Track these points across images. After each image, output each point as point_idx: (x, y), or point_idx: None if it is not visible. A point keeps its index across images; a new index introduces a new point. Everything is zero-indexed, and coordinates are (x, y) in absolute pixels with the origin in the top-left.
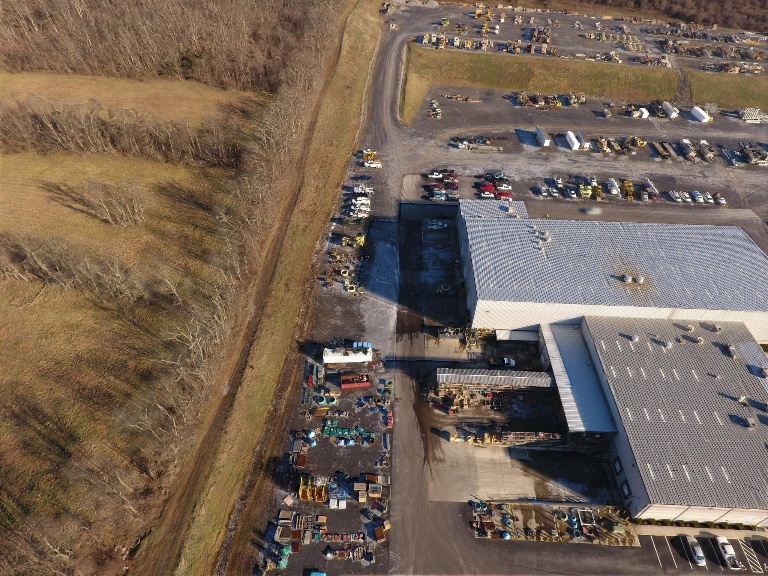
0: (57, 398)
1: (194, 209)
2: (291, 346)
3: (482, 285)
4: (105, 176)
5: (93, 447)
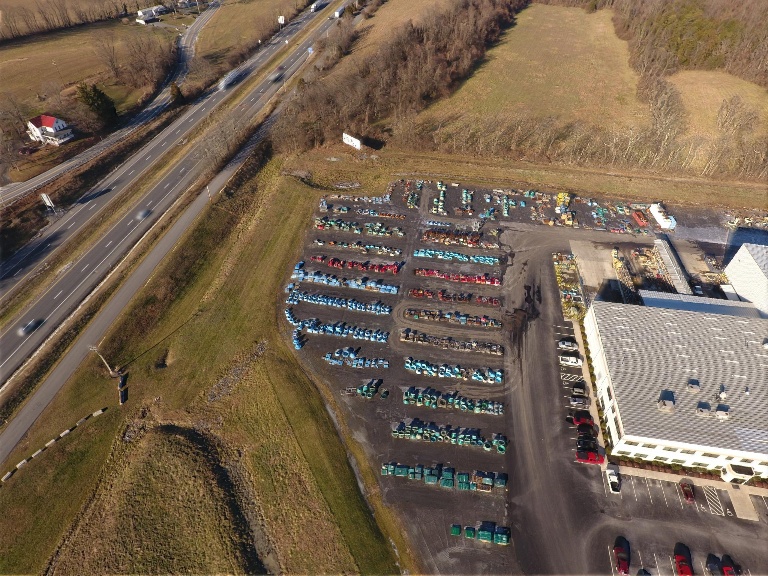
0: (585, 132)
1: (765, 152)
2: (657, 199)
3: (765, 248)
4: (767, 115)
5: (564, 144)
